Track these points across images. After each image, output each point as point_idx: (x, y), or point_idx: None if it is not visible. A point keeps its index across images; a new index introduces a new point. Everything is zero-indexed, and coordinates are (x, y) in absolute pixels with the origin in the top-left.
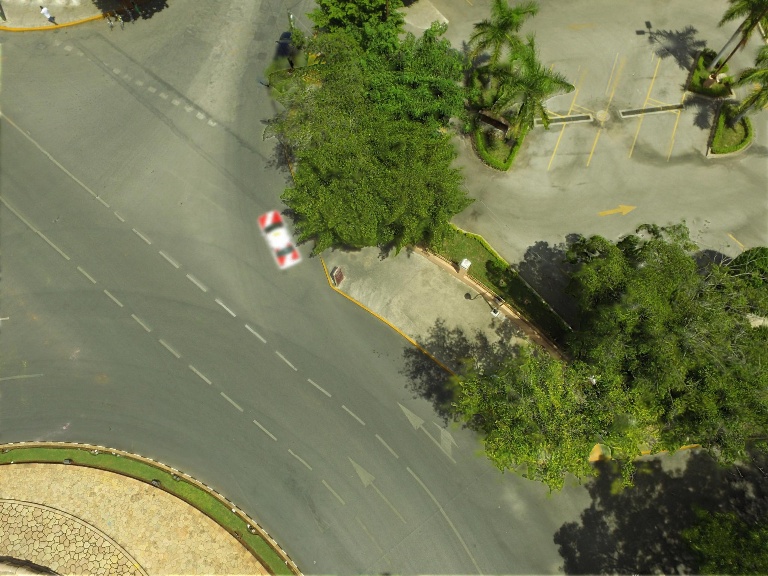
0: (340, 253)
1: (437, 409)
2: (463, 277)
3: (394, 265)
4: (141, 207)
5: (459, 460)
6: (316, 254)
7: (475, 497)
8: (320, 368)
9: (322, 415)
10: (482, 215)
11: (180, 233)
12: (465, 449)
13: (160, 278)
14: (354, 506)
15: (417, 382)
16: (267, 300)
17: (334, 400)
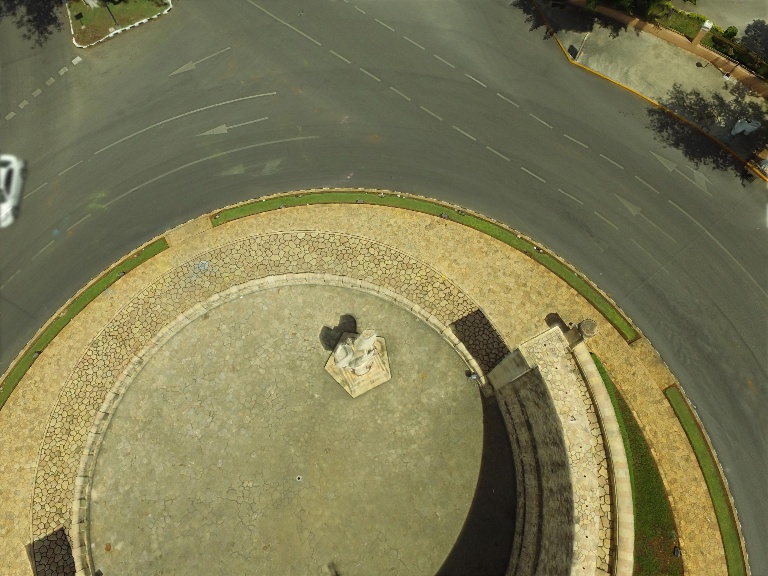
0: (573, 34)
1: (687, 155)
2: (696, 45)
3: (626, 42)
4: (379, 1)
5: (715, 194)
6: (549, 36)
7: (735, 221)
8: (573, 126)
9: (583, 162)
10: (699, 0)
11: (420, 22)
12: (718, 185)
13: (410, 58)
14: (627, 230)
15: (664, 135)
16: (512, 73)
17: (591, 150)
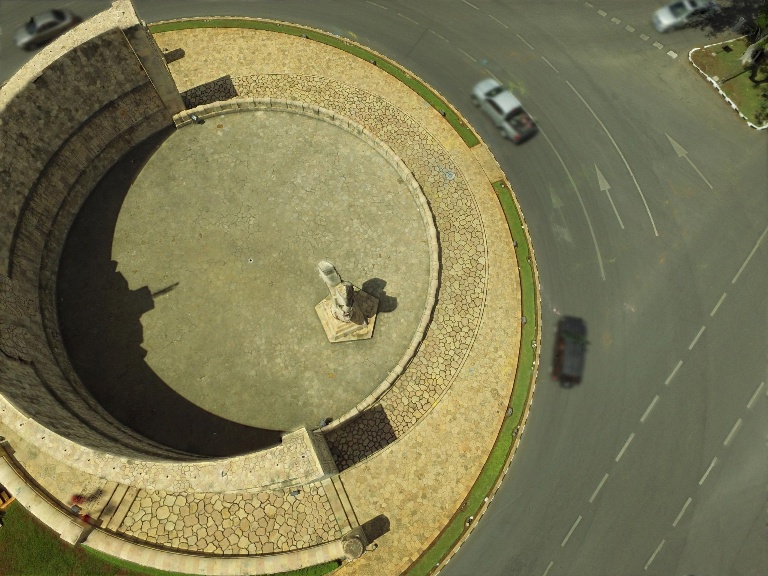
0: None
1: None
2: None
3: None
4: None
5: None
6: None
7: None
8: None
9: None
10: None
11: None
12: None
13: (731, 387)
14: None
15: None
16: (727, 524)
17: None
